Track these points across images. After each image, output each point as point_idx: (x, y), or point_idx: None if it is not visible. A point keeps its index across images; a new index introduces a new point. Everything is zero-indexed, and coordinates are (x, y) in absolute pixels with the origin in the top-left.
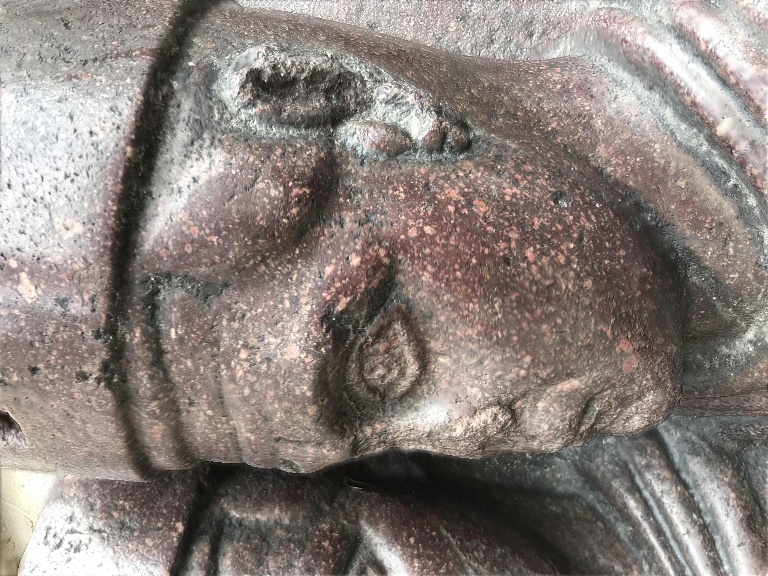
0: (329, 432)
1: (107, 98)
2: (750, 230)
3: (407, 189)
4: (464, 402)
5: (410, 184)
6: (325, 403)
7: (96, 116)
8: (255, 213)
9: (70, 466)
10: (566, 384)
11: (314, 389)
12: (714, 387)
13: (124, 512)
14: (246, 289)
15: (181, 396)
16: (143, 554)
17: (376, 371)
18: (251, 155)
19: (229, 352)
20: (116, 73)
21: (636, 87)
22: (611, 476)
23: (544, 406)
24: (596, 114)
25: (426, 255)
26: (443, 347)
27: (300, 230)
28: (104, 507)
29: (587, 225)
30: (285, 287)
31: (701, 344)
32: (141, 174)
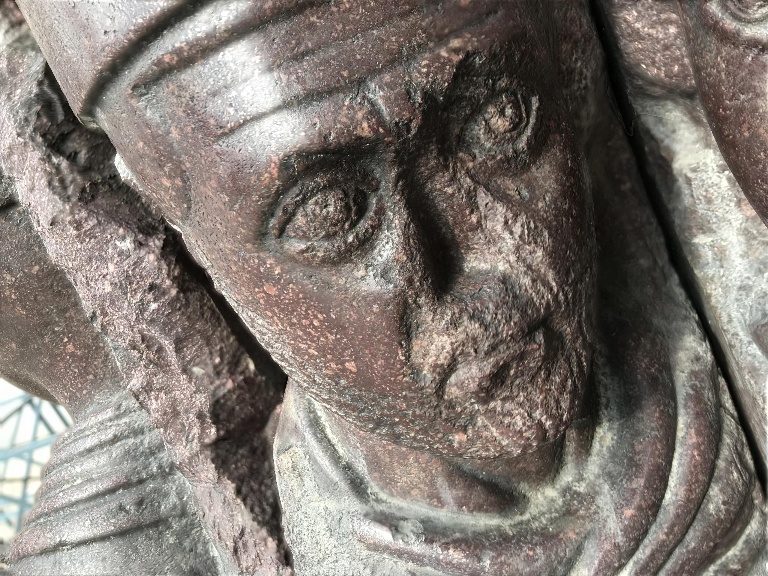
0: None
1: None
2: None
3: None
4: None
5: None
6: None
7: None
8: None
9: None
10: None
11: None
12: None
13: None
14: None
15: None
16: None
17: None
18: None
19: None
20: None
21: None
22: None
23: None
24: None
25: None
26: None
27: None
28: None
29: None
30: None
31: None
32: None
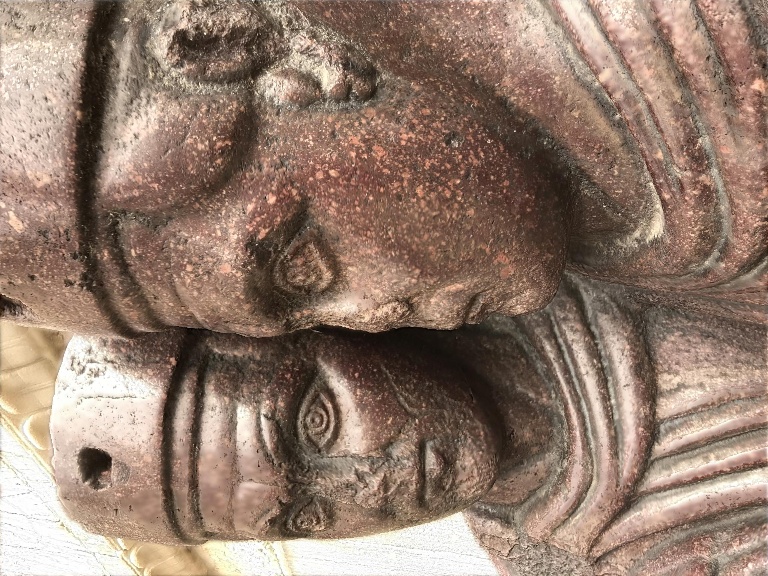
0: (264, 319)
1: (56, 65)
2: (633, 156)
3: (316, 137)
4: (370, 299)
5: (318, 132)
6: (257, 301)
7: (48, 83)
8: (186, 164)
9: (75, 331)
10: (452, 287)
11: (246, 294)
12: (609, 270)
13: (130, 348)
14: (186, 221)
15: (147, 293)
16: (146, 381)
17: (297, 277)
18: (181, 113)
19: (178, 266)
20: (61, 39)
21: (546, 17)
22: (535, 325)
23: (436, 302)
24: (507, 44)
25: (331, 194)
26: (350, 260)
27: (225, 176)
28: (114, 344)
29: (475, 162)
30: (216, 220)
31: (601, 235)
32: (91, 132)
